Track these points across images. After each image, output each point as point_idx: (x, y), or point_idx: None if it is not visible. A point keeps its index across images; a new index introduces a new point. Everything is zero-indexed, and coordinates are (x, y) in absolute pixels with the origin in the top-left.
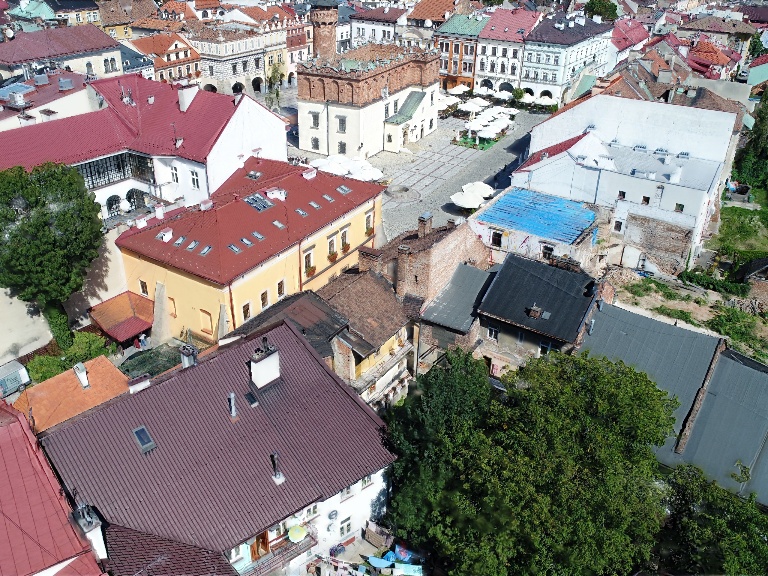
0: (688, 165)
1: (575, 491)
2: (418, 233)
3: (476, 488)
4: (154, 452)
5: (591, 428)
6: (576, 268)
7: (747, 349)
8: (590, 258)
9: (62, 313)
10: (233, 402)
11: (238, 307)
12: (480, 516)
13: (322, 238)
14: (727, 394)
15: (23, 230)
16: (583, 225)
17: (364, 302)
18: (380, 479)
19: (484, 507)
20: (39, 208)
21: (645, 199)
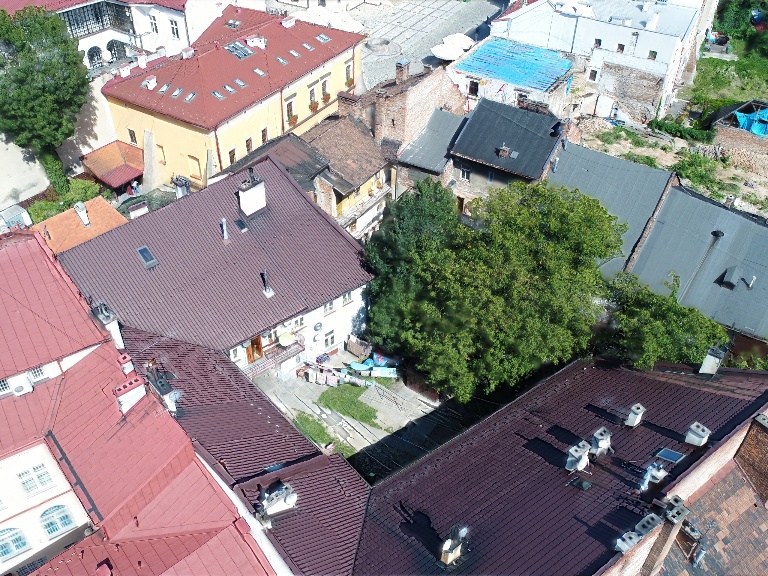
0: (666, 12)
1: (526, 293)
2: (396, 80)
3: (441, 296)
4: (157, 268)
5: (544, 244)
6: (545, 110)
7: (705, 191)
8: (564, 107)
9: (57, 159)
10: (225, 226)
11: (224, 152)
12: (445, 319)
13: (303, 87)
14: (674, 222)
15: (12, 75)
16: (558, 73)
17: (344, 145)
18: (359, 298)
19: (448, 311)
20: (26, 52)
21: (620, 47)
